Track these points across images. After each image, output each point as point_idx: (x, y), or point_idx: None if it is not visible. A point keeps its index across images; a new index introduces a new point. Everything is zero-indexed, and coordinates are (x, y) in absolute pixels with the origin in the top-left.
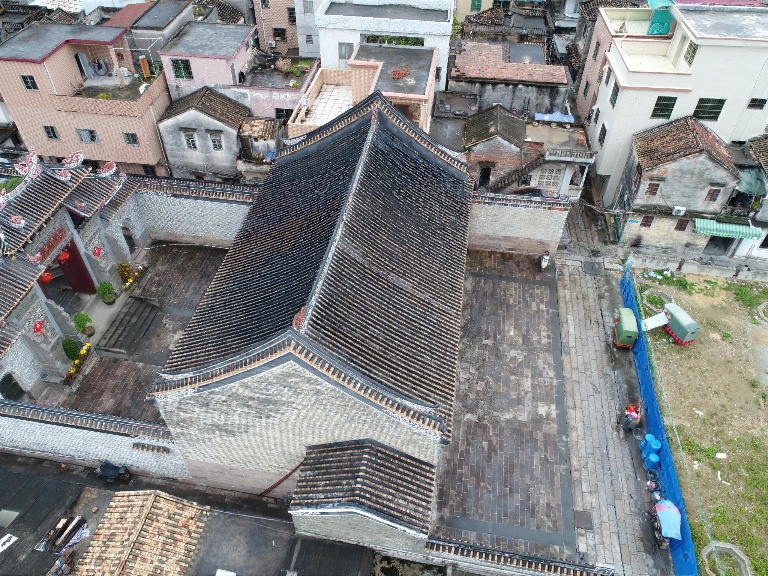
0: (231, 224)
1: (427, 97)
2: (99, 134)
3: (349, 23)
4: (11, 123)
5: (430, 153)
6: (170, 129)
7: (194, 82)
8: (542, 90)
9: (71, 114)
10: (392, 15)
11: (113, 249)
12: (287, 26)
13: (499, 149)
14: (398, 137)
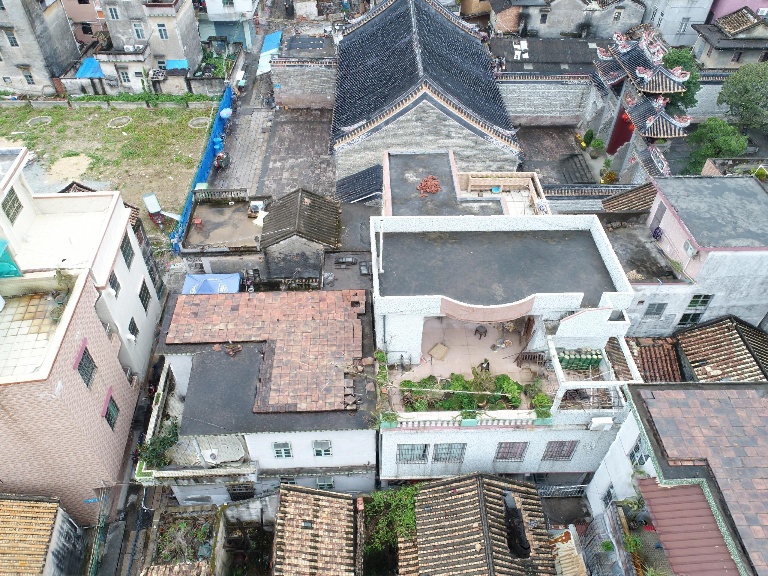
0: None
1: (385, 152)
2: None
3: None
4: None
5: None
6: None
7: None
8: None
9: None
10: (486, 274)
11: None
12: None
13: None
14: None
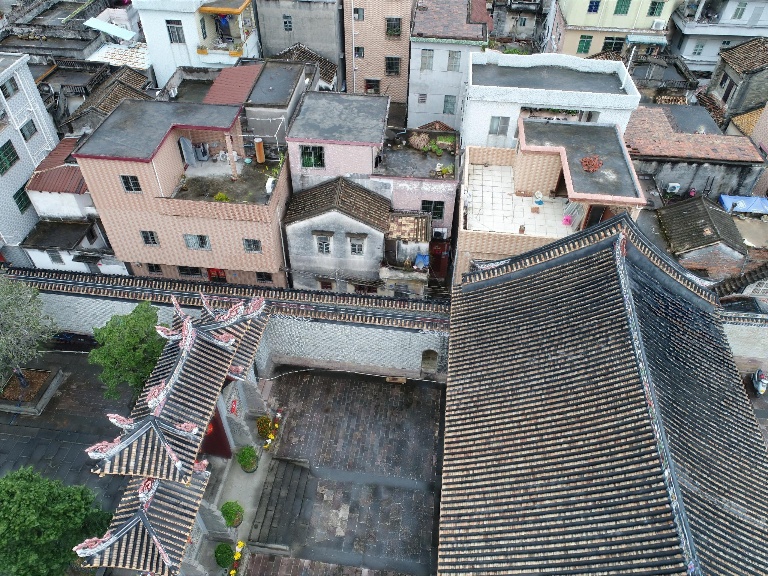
0: (381, 350)
1: (644, 200)
2: (212, 240)
3: (511, 95)
4: (86, 216)
5: (674, 283)
6: (300, 232)
7: (325, 171)
8: (731, 169)
9: (179, 218)
10: (552, 81)
11: (248, 397)
12: (382, 77)
13: (717, 256)
14: (638, 265)
